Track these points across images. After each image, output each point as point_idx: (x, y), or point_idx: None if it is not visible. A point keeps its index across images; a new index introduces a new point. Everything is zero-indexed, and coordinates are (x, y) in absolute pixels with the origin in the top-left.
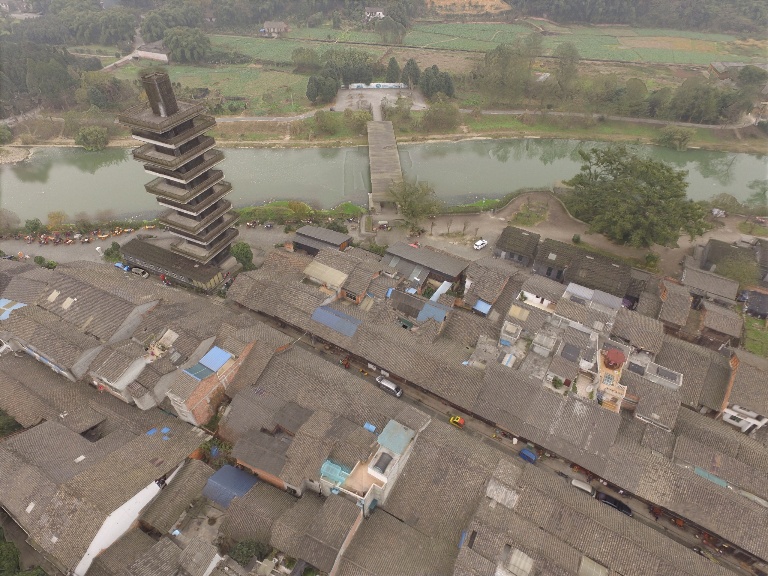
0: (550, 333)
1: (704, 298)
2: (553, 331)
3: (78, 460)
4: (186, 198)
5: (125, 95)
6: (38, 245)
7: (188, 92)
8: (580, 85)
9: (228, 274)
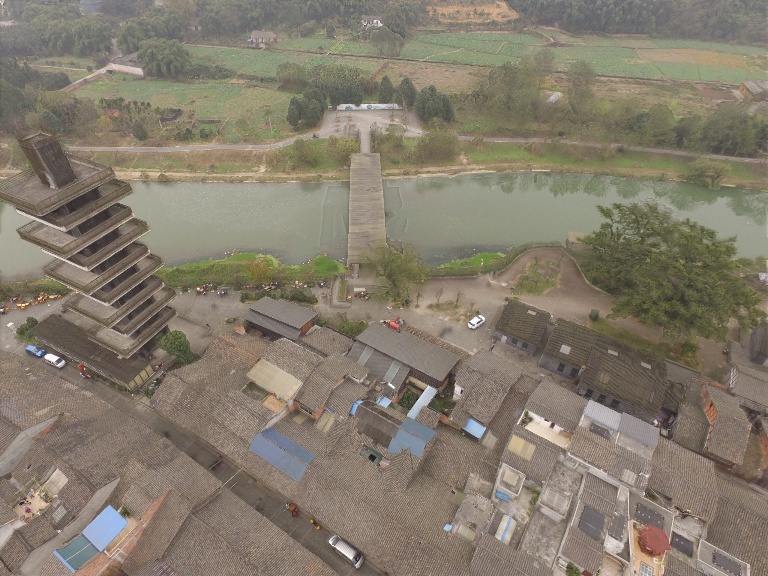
0: (563, 479)
1: (762, 415)
2: (567, 476)
3: None
4: (91, 288)
5: (87, 117)
6: None
7: (158, 113)
8: (597, 111)
9: (161, 365)
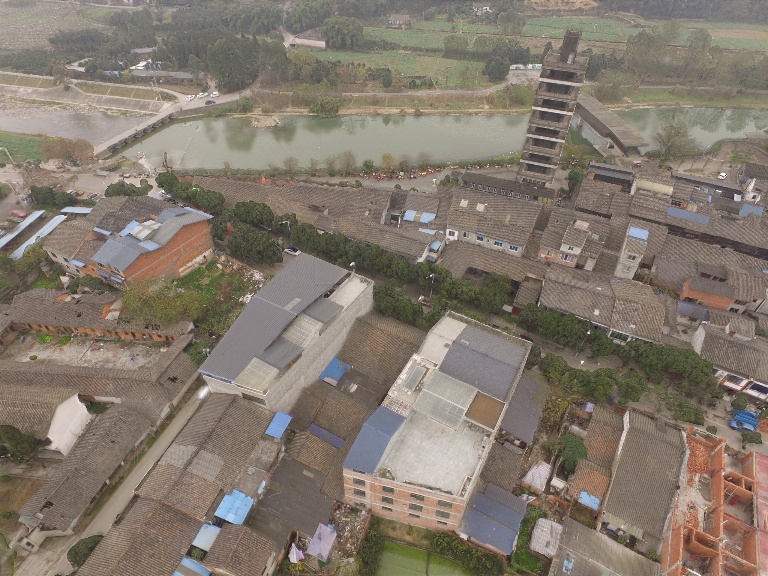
0: None
1: None
2: None
3: None
4: None
5: (326, 73)
6: (376, 180)
7: (374, 72)
8: (722, 63)
9: None
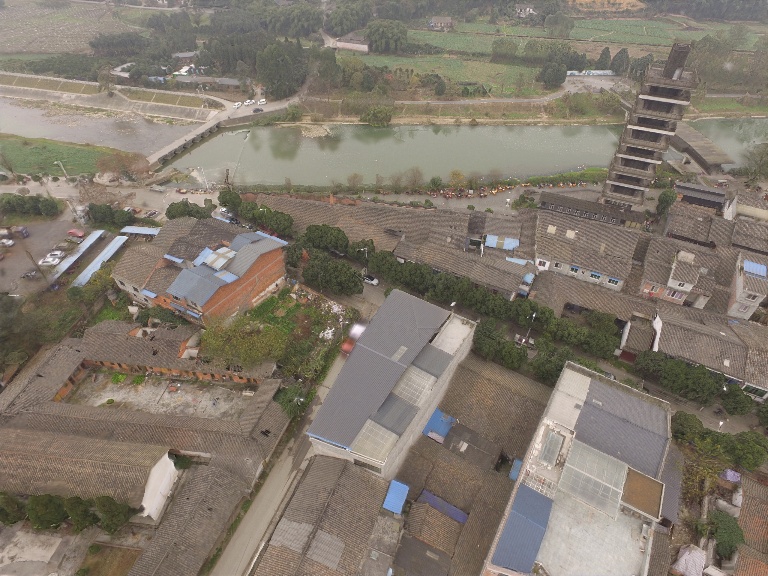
0: None
1: None
2: None
3: (724, 334)
4: None
5: (374, 80)
6: (444, 199)
7: (423, 78)
8: None
9: None
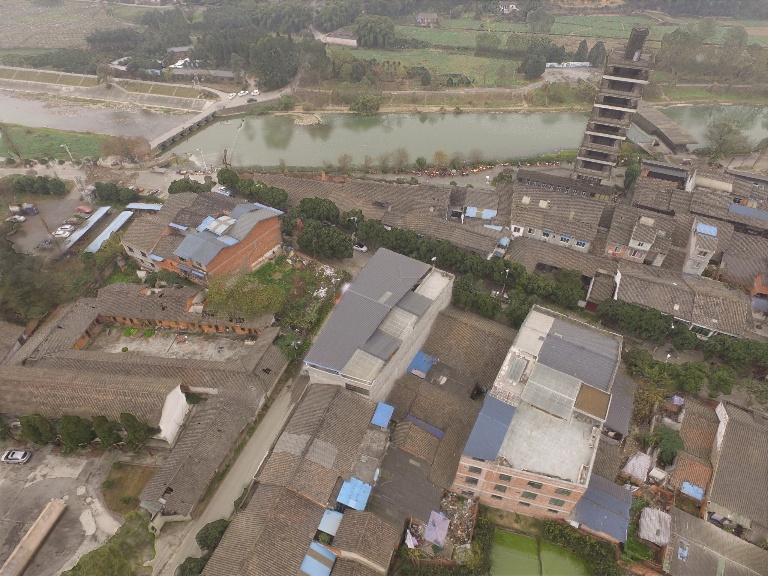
0: None
1: None
2: None
3: (675, 284)
4: None
5: (363, 72)
6: (429, 177)
7: (409, 70)
8: (760, 61)
9: None
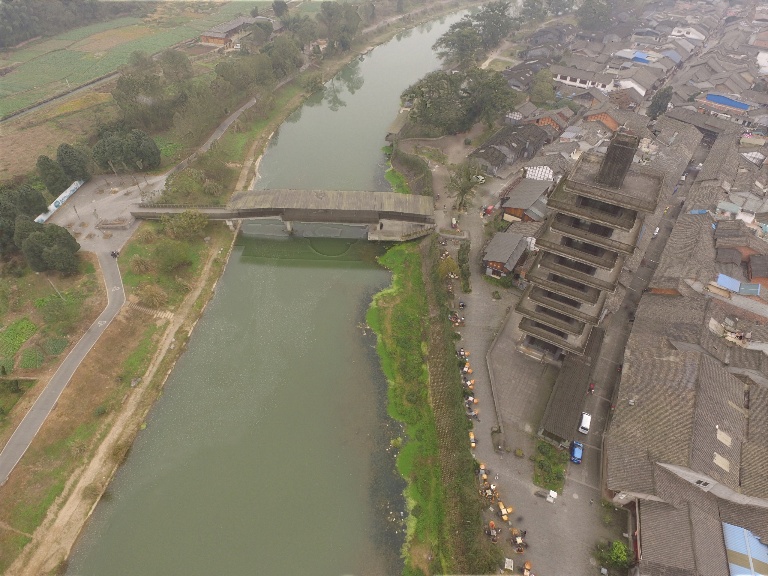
0: None
1: None
2: None
3: None
4: None
5: None
6: None
7: None
8: (236, 78)
9: None
